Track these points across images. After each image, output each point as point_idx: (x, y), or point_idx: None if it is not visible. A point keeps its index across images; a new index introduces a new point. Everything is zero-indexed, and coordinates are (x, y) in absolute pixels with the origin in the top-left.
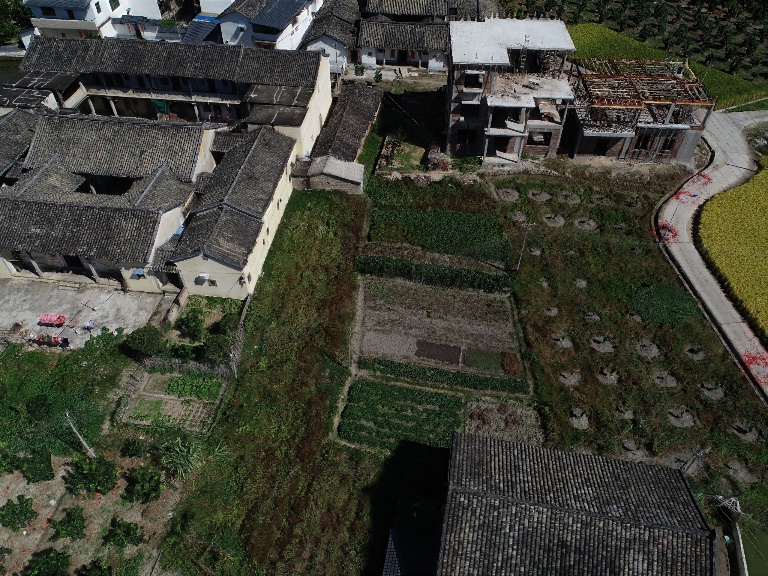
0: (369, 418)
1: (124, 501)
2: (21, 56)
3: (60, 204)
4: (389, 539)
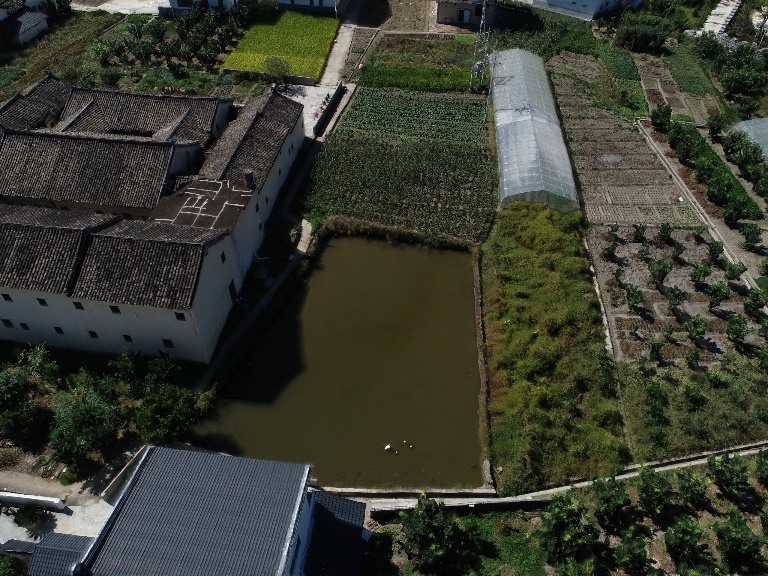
0: (6, 75)
1: (135, 59)
2: (356, 490)
3: (150, 95)
4: (20, 33)
